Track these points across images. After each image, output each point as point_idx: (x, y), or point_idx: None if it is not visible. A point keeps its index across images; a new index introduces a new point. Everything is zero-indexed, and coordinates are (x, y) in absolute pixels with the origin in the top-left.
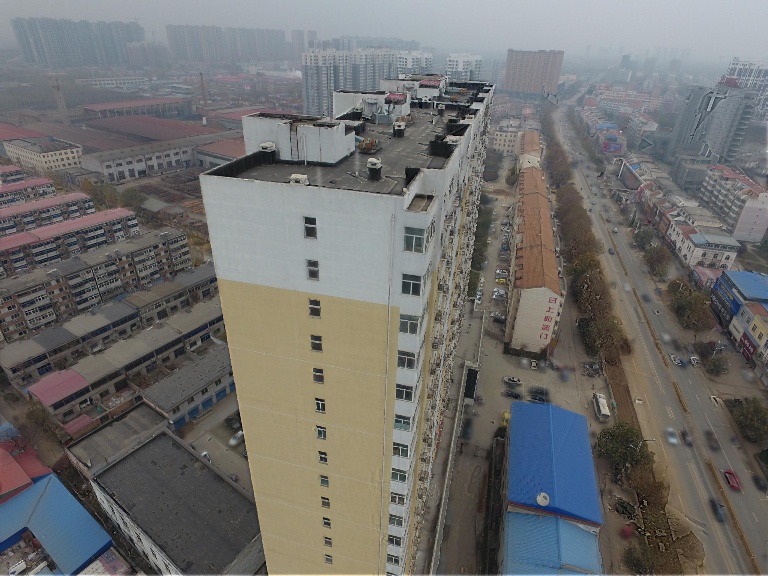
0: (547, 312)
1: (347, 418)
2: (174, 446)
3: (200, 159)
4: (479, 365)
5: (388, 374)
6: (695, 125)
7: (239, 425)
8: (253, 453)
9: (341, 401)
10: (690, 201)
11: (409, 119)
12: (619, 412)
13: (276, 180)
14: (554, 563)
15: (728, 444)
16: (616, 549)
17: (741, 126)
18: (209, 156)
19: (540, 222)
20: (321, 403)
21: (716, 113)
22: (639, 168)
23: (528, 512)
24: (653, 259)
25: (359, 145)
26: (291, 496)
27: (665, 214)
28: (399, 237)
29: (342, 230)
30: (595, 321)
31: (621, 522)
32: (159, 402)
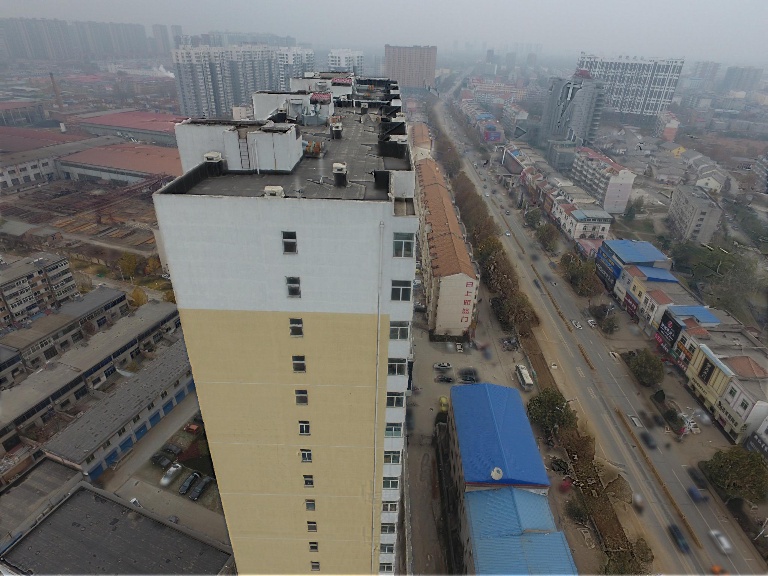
0: (466, 296)
1: (334, 436)
2: (98, 500)
3: (65, 171)
4: (413, 356)
5: (378, 384)
6: (560, 113)
7: (169, 461)
8: (227, 492)
9: (328, 419)
10: (566, 181)
11: (338, 119)
12: (539, 379)
13: (236, 193)
14: (516, 531)
15: (629, 392)
16: (558, 504)
17: (596, 112)
18: (77, 167)
19: (445, 211)
20: (305, 425)
21: (576, 102)
22: (519, 154)
23: (484, 488)
24: (544, 236)
25: (306, 149)
26: (273, 528)
27: (548, 195)
28: (388, 243)
29: (326, 242)
30: (505, 299)
31: (558, 479)
32: (67, 454)
